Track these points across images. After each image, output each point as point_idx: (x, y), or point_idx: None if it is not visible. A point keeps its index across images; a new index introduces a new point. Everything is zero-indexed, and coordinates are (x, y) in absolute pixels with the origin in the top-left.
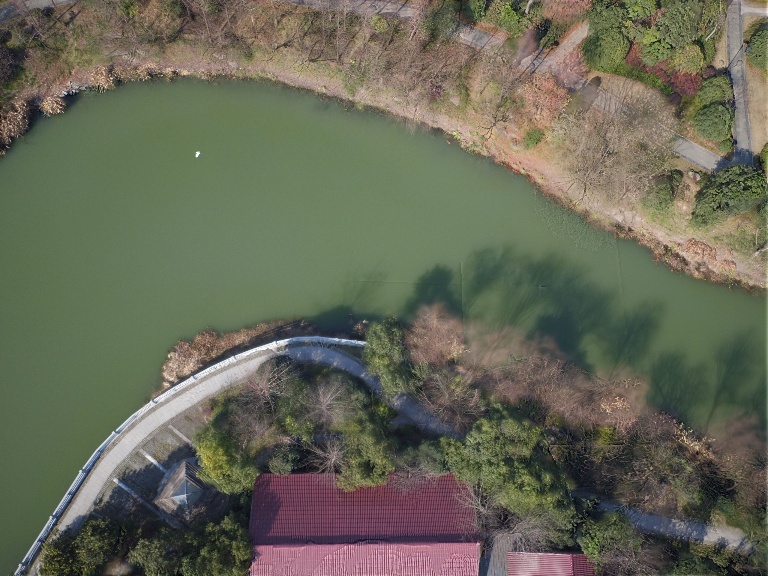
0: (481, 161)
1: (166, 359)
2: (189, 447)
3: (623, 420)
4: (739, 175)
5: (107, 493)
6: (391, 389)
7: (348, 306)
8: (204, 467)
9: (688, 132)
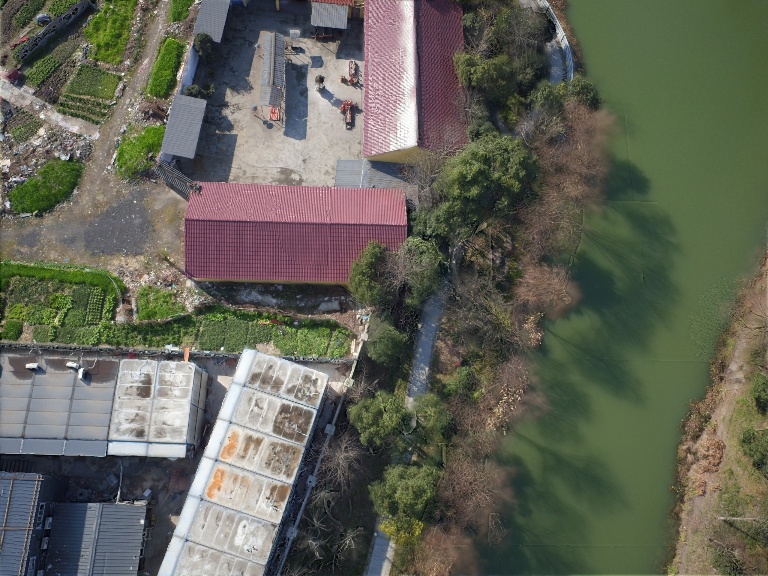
0: (767, 230)
1: None
2: None
3: (519, 334)
4: None
5: None
6: None
7: None
8: None
9: None
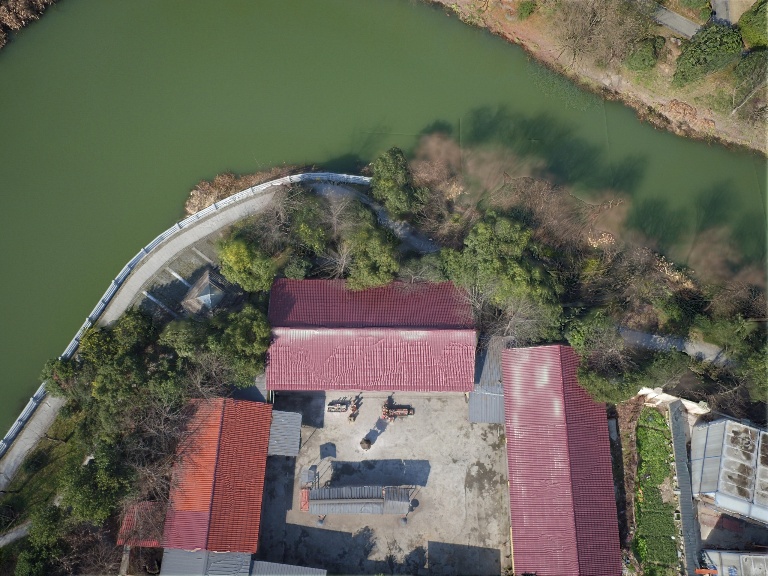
0: (478, 32)
1: (189, 196)
2: (211, 266)
3: (609, 252)
4: (716, 32)
5: (137, 303)
6: (395, 206)
7: (355, 154)
8: (226, 276)
9: (670, 3)
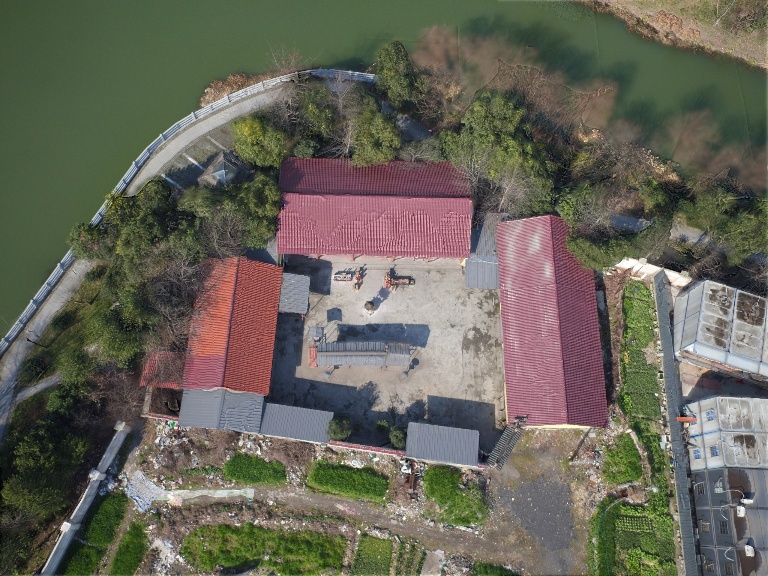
0: None
1: (203, 93)
2: None
3: (598, 145)
4: None
5: None
6: (397, 93)
7: (359, 57)
8: (239, 156)
9: None
